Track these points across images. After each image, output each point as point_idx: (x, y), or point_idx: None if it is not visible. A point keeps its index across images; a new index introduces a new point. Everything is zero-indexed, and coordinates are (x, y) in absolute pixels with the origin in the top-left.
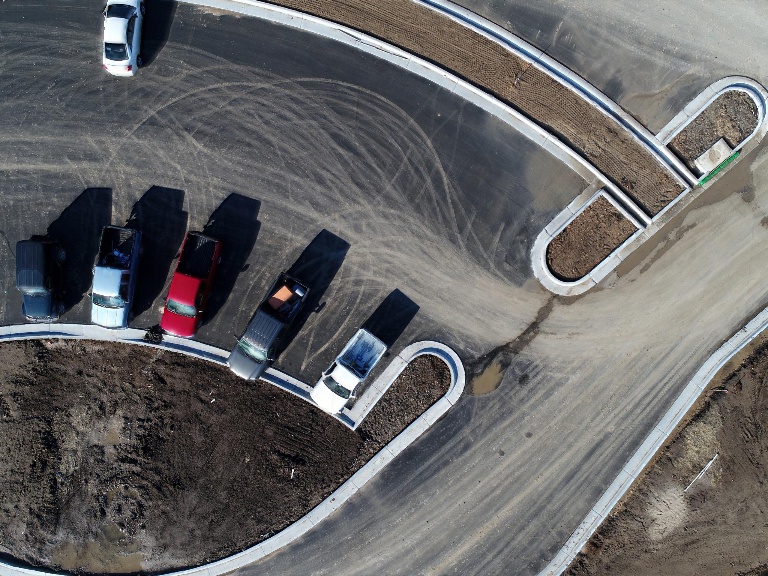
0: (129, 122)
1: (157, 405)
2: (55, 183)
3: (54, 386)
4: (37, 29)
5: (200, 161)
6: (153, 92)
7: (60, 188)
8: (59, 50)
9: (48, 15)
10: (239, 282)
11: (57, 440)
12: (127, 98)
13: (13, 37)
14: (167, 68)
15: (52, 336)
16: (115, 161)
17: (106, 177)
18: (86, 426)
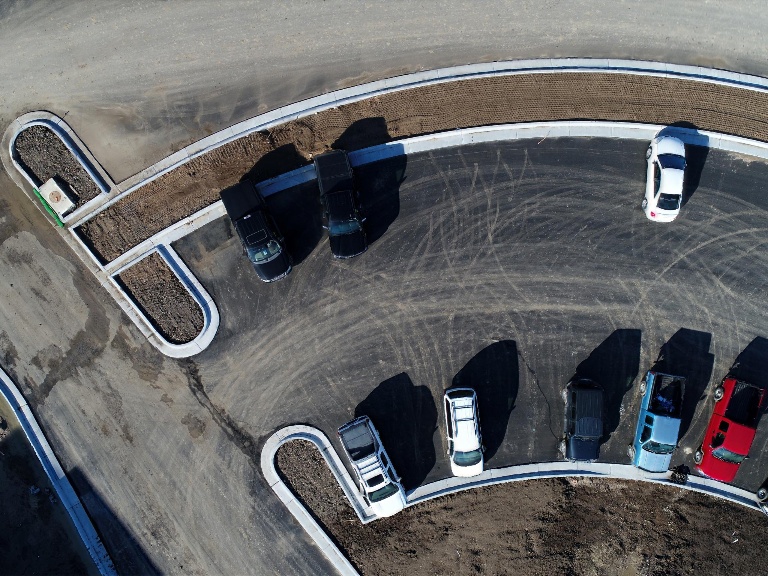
0: (659, 265)
1: (677, 543)
2: (585, 323)
3: (577, 523)
4: (571, 172)
5: (727, 304)
6: (683, 236)
7: (590, 329)
8: (592, 193)
9: (582, 158)
10: (762, 424)
11: (578, 575)
12: (657, 241)
13: (547, 179)
14: (697, 212)
15: (581, 475)
16: (645, 303)
17: (636, 319)
18: (606, 562)
